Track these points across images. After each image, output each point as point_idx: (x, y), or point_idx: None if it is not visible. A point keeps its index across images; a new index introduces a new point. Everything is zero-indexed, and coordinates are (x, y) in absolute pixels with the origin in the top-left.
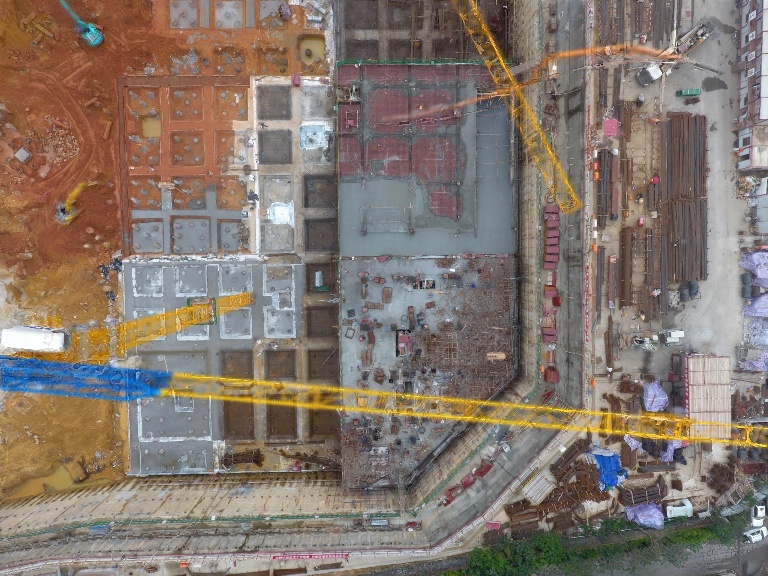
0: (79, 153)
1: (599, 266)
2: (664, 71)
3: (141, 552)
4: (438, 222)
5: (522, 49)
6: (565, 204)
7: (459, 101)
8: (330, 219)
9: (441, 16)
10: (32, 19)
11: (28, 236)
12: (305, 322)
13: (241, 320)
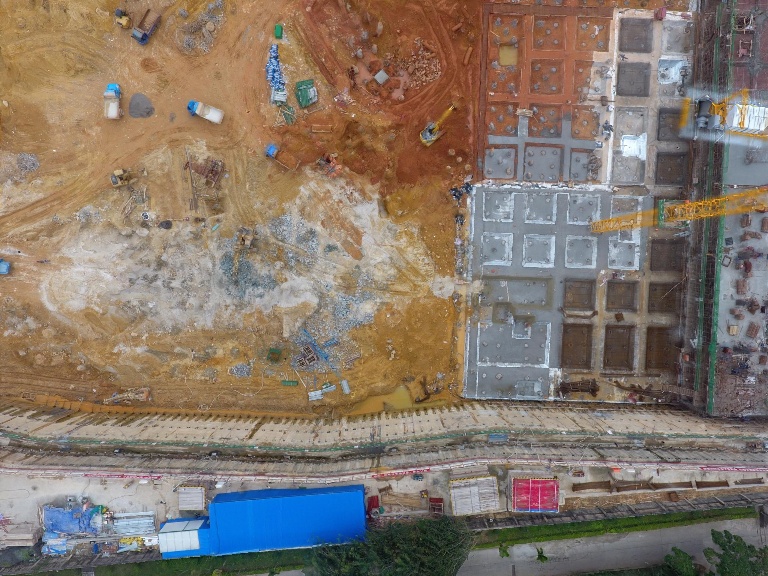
0: (440, 77)
1: None
2: None
3: (566, 456)
4: None
5: None
6: None
7: None
8: (681, 153)
9: None
10: None
11: (389, 156)
12: (649, 254)
13: (583, 250)
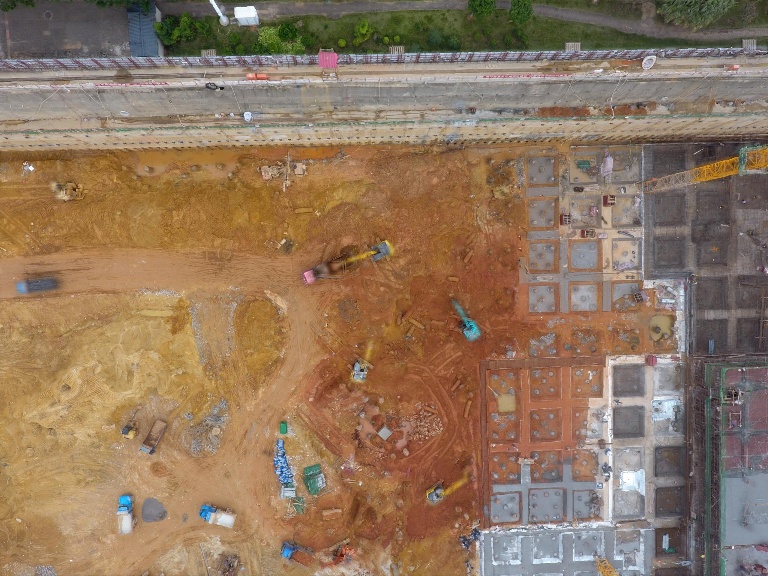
0: (442, 432)
1: None
2: None
3: None
4: None
5: None
6: None
7: None
8: (679, 486)
9: None
10: (409, 316)
11: (397, 514)
12: None
13: None
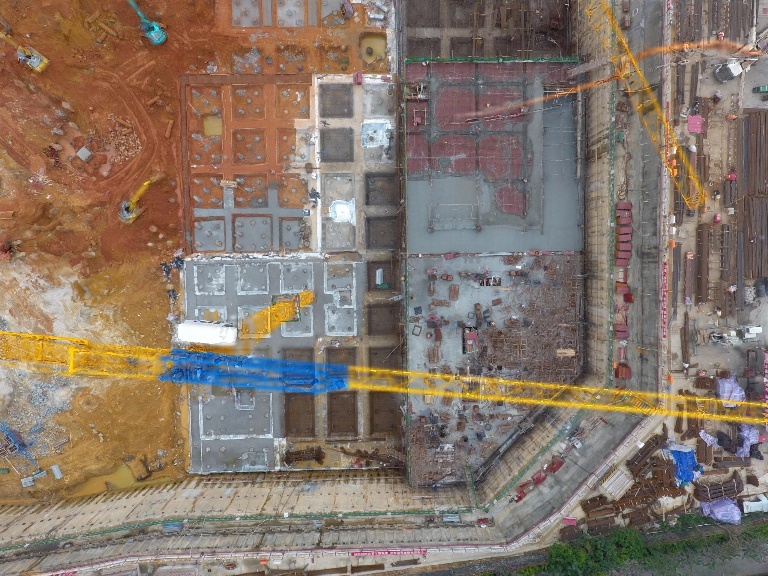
0: (141, 152)
1: (675, 262)
2: (744, 68)
3: (219, 549)
4: (505, 219)
5: (589, 46)
6: (690, 199)
7: (526, 98)
8: (391, 217)
9: (503, 14)
10: (96, 18)
11: (91, 235)
12: (366, 320)
13: (302, 318)
